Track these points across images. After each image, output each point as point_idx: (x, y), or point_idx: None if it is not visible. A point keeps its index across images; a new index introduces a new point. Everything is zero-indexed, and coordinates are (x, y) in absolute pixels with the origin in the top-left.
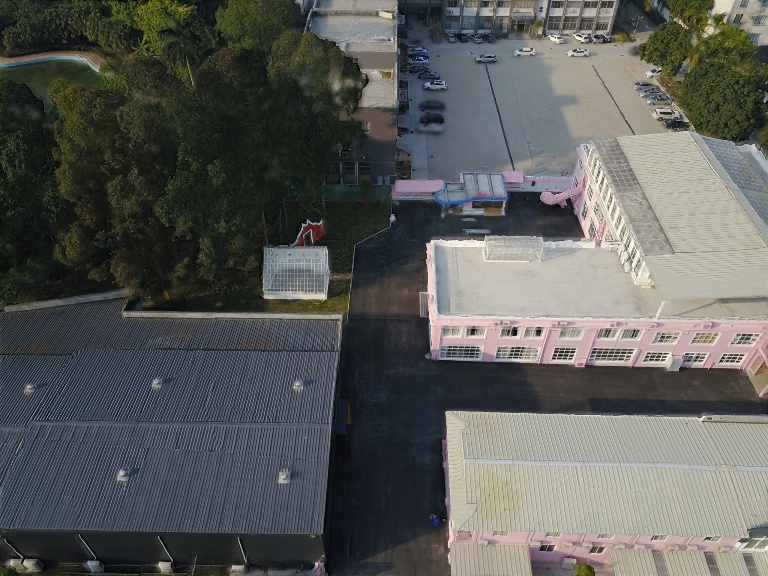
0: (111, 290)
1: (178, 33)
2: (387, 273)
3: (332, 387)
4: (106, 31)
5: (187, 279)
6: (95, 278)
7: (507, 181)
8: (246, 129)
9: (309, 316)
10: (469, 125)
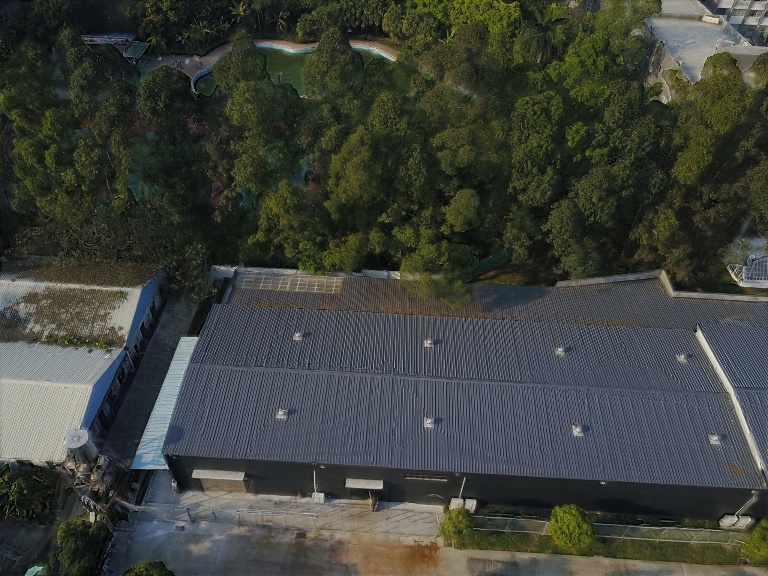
0: (645, 271)
1: (545, 28)
2: None
3: None
4: (415, 23)
5: (649, 265)
6: (643, 258)
7: None
8: None
9: None
10: None
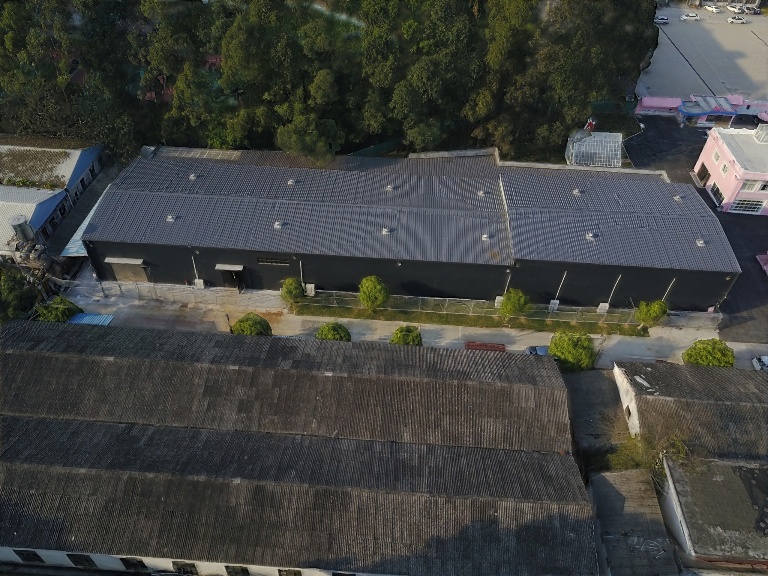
0: (482, 148)
1: None
2: (657, 160)
3: (702, 200)
4: None
5: None
6: (477, 136)
7: (730, 103)
8: (613, 25)
9: (639, 171)
10: (667, 68)
